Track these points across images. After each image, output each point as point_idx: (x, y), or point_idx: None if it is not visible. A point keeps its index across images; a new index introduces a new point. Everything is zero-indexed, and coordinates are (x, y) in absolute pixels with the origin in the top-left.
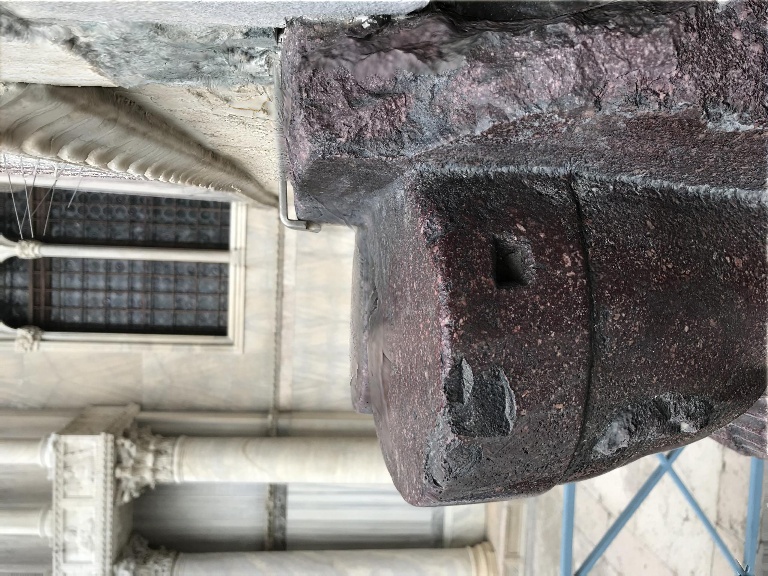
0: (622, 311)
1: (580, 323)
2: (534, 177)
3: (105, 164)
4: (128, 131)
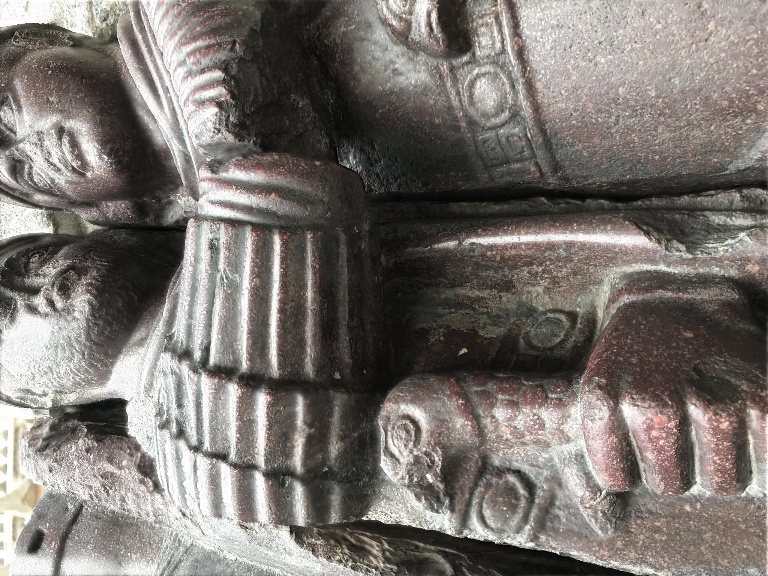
0: (71, 572)
1: (49, 575)
2: (71, 498)
3: None
4: None
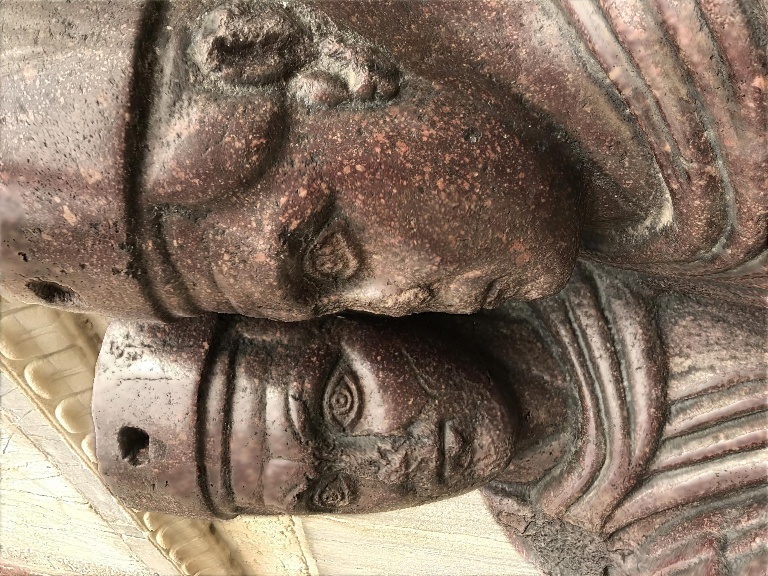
0: None
1: None
2: None
3: (52, 406)
4: (76, 349)
